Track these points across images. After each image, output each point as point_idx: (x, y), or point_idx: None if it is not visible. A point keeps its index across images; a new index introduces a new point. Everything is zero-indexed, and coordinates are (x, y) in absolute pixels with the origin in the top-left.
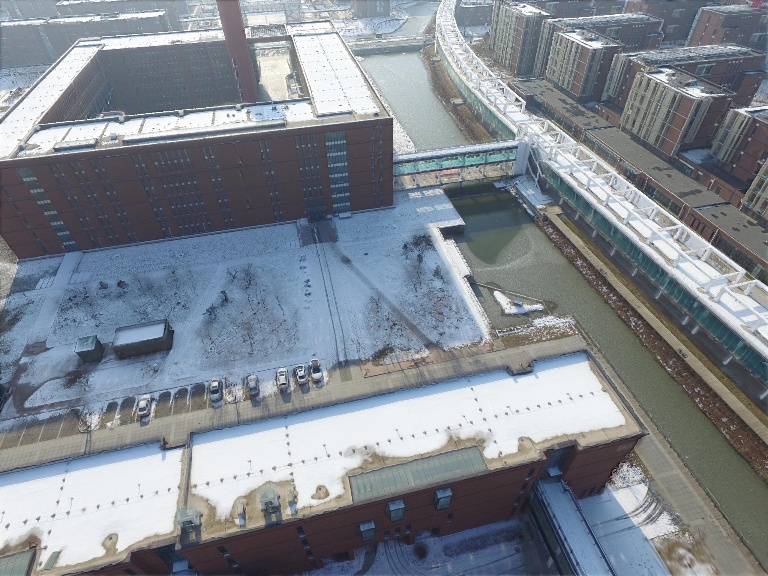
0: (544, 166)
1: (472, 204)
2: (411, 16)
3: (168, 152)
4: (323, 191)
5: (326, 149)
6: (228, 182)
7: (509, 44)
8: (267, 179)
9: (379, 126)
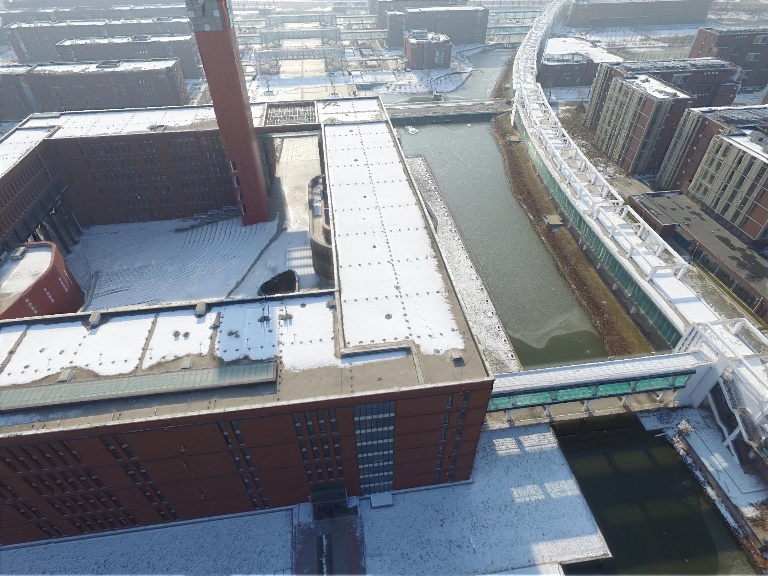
0: (751, 421)
1: (609, 473)
2: (475, 68)
3: (29, 446)
4: (344, 472)
5: (355, 425)
6: (161, 474)
7: (622, 131)
8: (238, 464)
9: (464, 391)
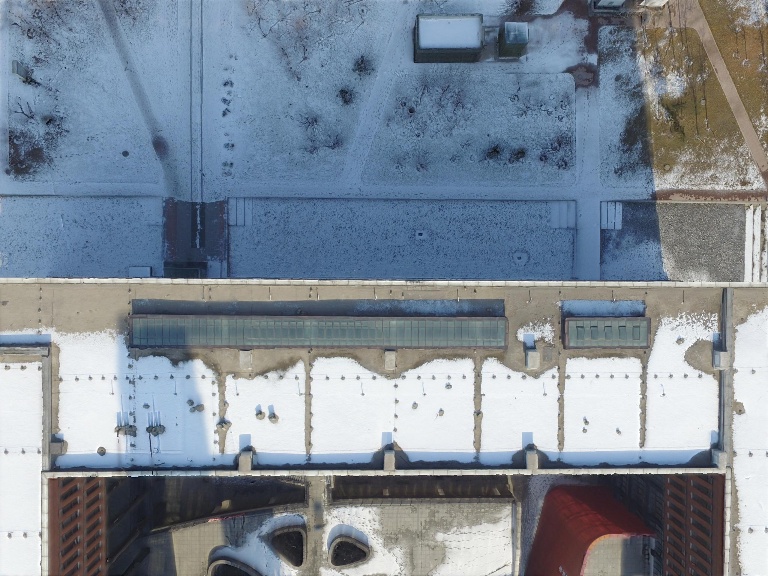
0: None
1: None
2: None
3: None
4: None
5: None
6: None
7: None
8: None
9: None
